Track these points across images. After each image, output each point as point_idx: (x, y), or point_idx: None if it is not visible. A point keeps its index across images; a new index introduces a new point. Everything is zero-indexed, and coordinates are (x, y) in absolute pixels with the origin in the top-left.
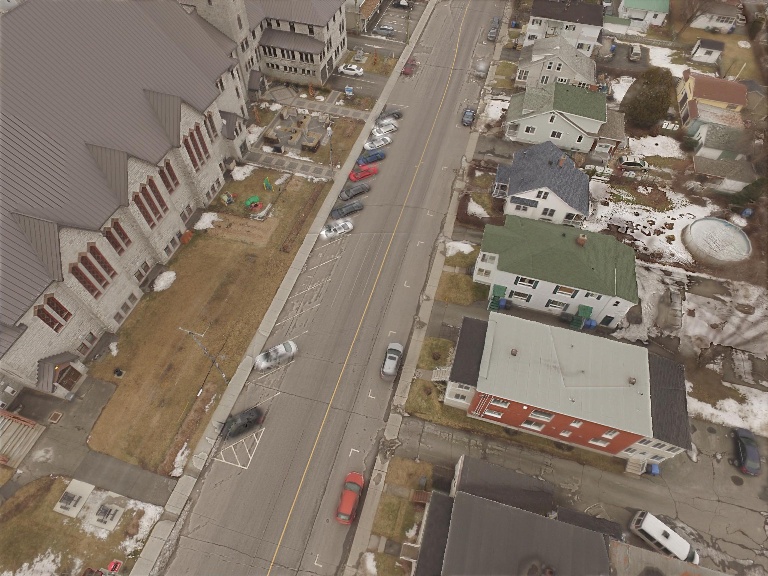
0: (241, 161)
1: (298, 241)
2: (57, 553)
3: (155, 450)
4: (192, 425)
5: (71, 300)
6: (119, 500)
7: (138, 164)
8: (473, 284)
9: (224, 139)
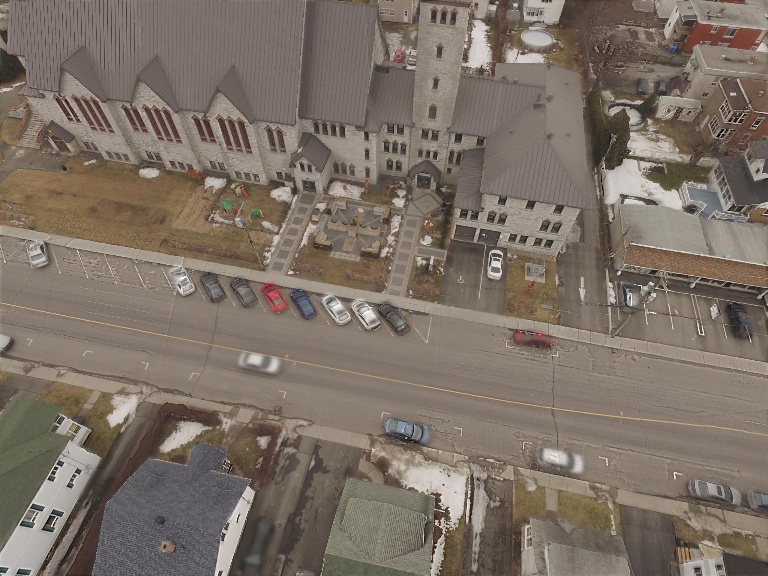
0: (299, 190)
1: (174, 251)
2: None
3: None
4: (2, 215)
5: None
6: None
7: None
8: None
9: None
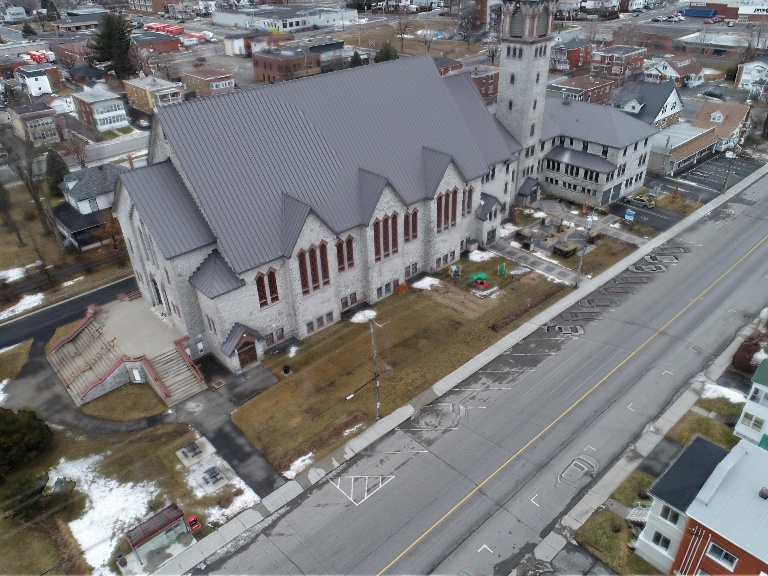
0: (484, 247)
1: (513, 326)
2: (158, 488)
3: (281, 446)
4: (325, 440)
5: (285, 286)
6: (229, 472)
7: (392, 196)
8: (732, 437)
9: (475, 219)
